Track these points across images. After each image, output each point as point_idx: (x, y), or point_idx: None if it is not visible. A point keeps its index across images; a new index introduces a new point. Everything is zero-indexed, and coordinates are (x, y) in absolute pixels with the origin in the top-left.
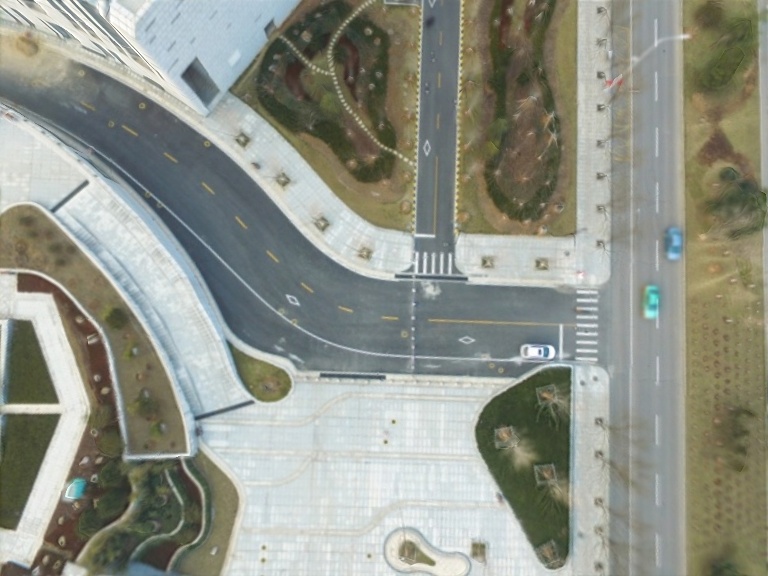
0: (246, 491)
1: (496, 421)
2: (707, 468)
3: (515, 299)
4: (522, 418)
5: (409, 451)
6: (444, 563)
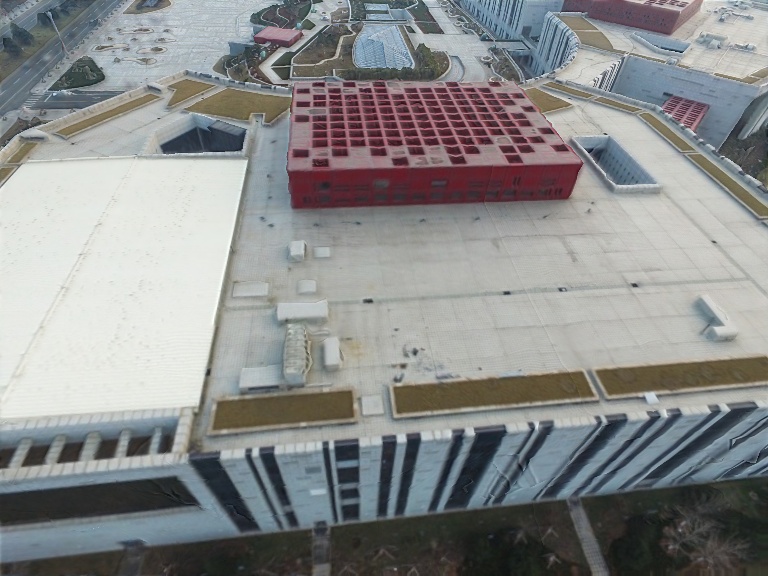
0: (210, 70)
1: (93, 81)
2: (0, 73)
3: (65, 106)
4: (80, 80)
5: (137, 77)
6: (132, 59)
